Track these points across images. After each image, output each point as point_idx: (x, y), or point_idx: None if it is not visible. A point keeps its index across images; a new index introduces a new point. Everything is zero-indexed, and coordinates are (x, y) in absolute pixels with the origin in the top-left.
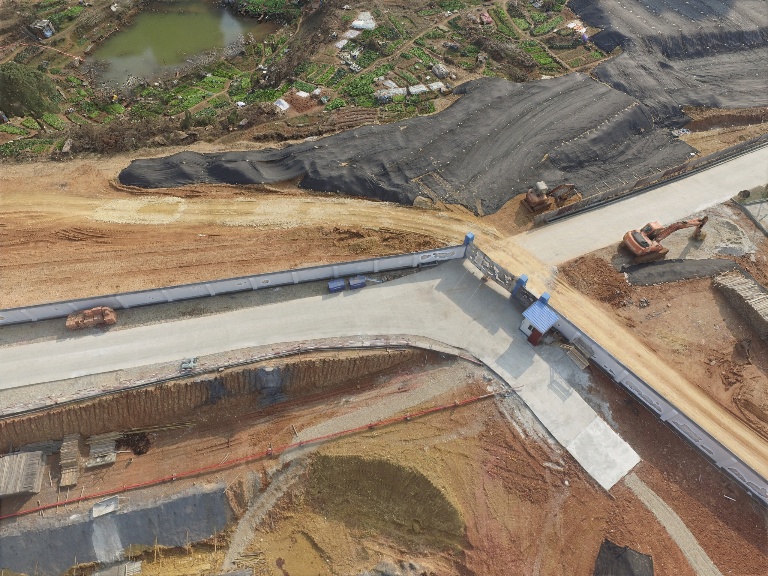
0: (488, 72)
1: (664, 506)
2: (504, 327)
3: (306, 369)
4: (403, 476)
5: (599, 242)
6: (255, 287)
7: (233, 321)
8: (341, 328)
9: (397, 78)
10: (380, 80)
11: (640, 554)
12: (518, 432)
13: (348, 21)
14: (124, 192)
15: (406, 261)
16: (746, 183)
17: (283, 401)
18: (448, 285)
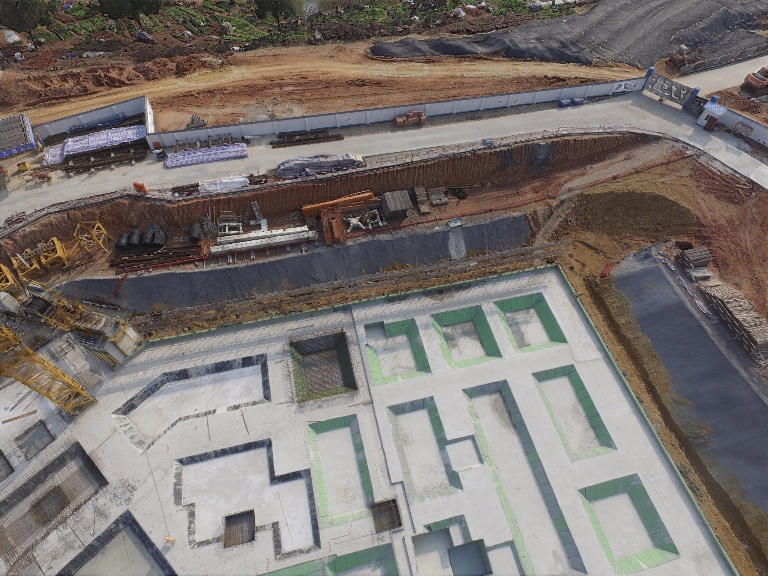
0: None
1: None
2: (685, 123)
3: (564, 145)
4: (646, 199)
5: (727, 84)
6: (509, 105)
7: (504, 122)
8: (579, 124)
9: None
10: None
11: None
12: (715, 171)
13: None
14: (378, 60)
15: (606, 90)
16: None
17: (547, 170)
18: (638, 103)
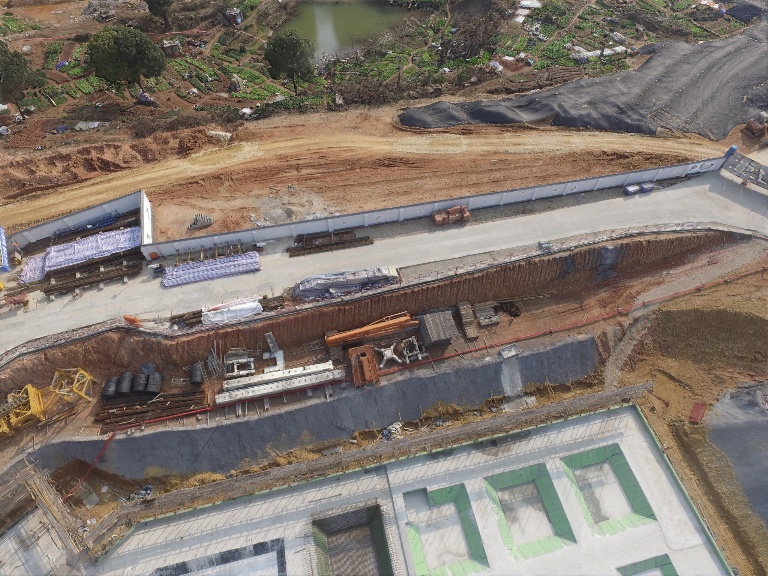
0: (653, 39)
1: None
2: None
3: (635, 248)
4: (741, 320)
5: None
6: (565, 193)
7: (562, 216)
8: (650, 219)
9: (583, 44)
10: (569, 46)
11: None
12: None
13: (515, 2)
14: (409, 132)
15: (678, 171)
16: None
17: (614, 276)
18: (717, 188)
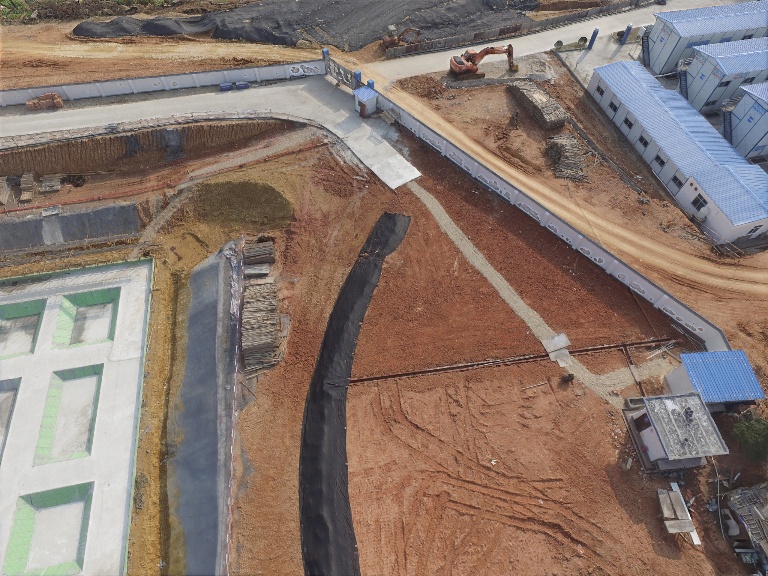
0: None
1: (429, 196)
2: (344, 109)
3: (197, 132)
4: (258, 189)
5: (434, 69)
6: (167, 88)
7: (148, 106)
8: (226, 109)
9: None
10: None
11: (404, 216)
12: (339, 161)
13: None
14: (77, 41)
15: (281, 73)
16: (566, 41)
17: (182, 157)
18: (310, 88)
